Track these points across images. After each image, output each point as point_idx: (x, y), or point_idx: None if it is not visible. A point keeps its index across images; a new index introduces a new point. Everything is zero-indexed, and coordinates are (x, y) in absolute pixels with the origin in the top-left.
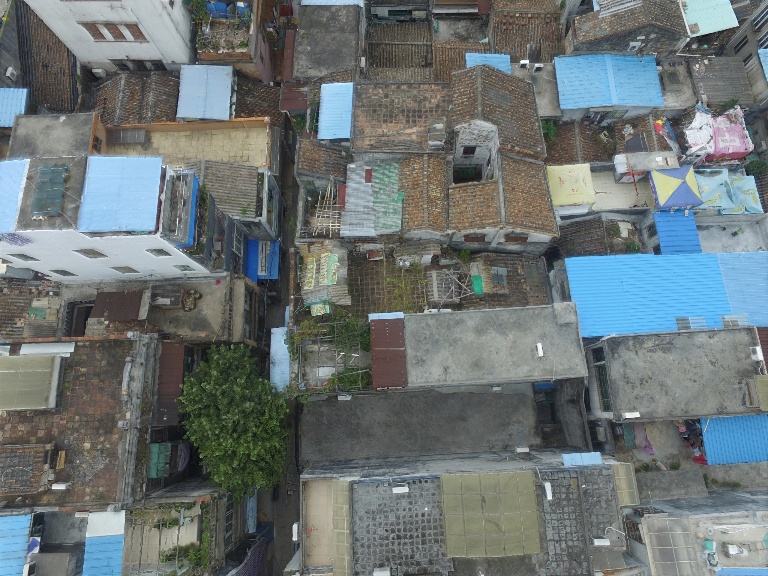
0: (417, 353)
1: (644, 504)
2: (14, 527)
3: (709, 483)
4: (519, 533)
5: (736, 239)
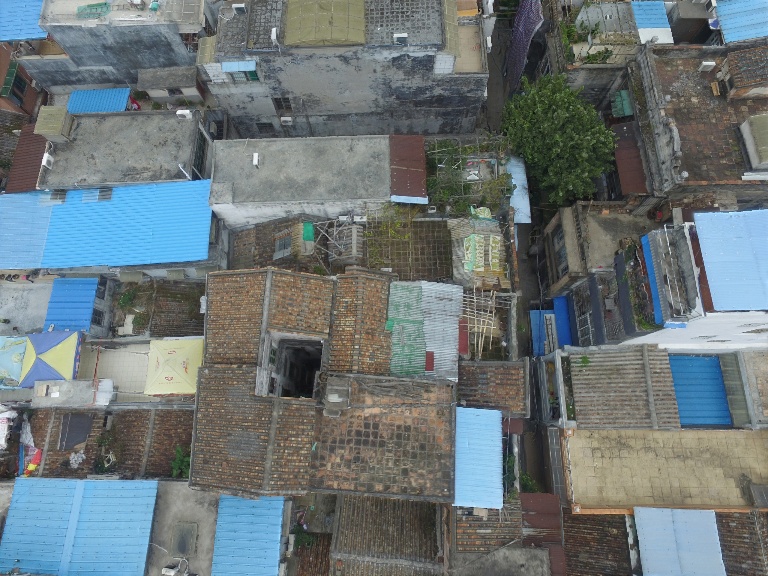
0: (379, 164)
1: (194, 59)
2: (738, 33)
3: (133, 94)
4: (304, 4)
5: (8, 317)
